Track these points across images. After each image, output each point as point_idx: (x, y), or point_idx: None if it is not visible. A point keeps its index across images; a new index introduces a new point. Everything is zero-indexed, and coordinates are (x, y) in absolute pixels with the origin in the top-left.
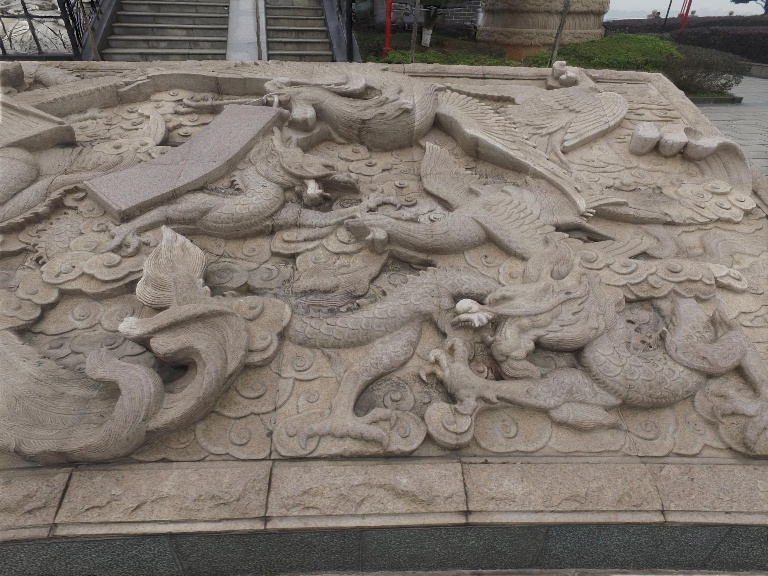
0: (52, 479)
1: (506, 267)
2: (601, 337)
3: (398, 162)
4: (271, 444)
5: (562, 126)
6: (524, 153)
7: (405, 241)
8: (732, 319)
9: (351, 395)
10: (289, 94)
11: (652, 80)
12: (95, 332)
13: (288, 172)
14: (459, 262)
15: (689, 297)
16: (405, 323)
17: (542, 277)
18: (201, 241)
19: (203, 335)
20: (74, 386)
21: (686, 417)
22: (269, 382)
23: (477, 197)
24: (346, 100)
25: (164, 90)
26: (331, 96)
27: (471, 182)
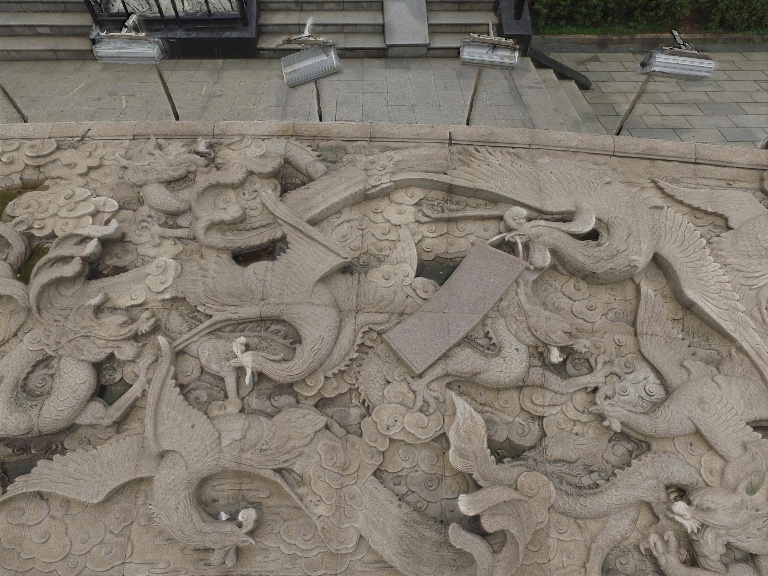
0: None
1: (707, 461)
2: None
3: (612, 300)
4: None
5: None
6: (734, 324)
7: (632, 428)
8: None
9: (600, 565)
10: (529, 237)
11: None
12: (418, 473)
13: (535, 336)
14: (669, 446)
15: None
16: (631, 505)
17: (740, 493)
18: (467, 387)
19: (512, 520)
20: (427, 528)
21: None
22: (543, 540)
23: (688, 376)
24: (579, 245)
25: (401, 188)
26: (566, 240)
27: (682, 350)
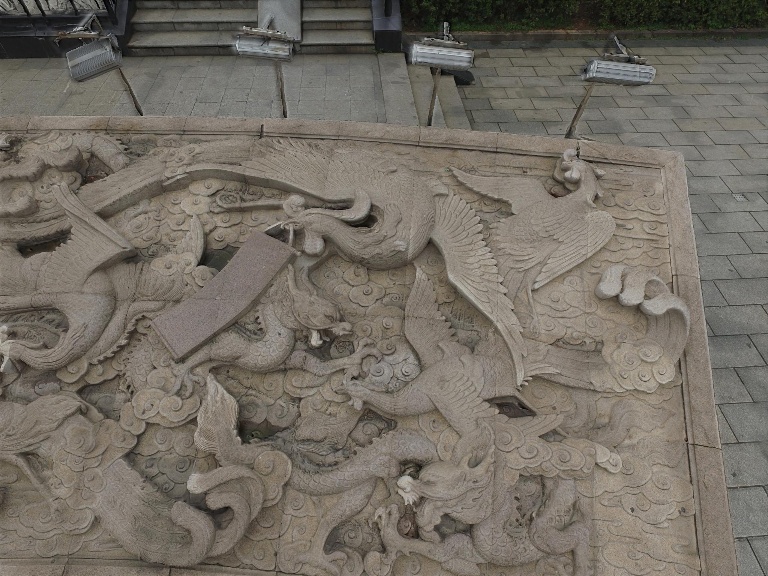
0: (161, 572)
1: (445, 436)
2: (486, 520)
3: (392, 285)
4: (276, 562)
5: (540, 262)
6: (492, 305)
7: (376, 407)
8: (596, 497)
9: (323, 539)
10: (303, 224)
11: (667, 166)
12: (171, 456)
13: None
14: (413, 424)
15: (569, 479)
16: (365, 481)
17: (461, 465)
18: (235, 372)
19: (236, 497)
20: (165, 508)
21: (528, 574)
22: (276, 516)
23: (441, 356)
24: (351, 232)
25: (200, 179)
26: (338, 227)
27: (442, 332)
